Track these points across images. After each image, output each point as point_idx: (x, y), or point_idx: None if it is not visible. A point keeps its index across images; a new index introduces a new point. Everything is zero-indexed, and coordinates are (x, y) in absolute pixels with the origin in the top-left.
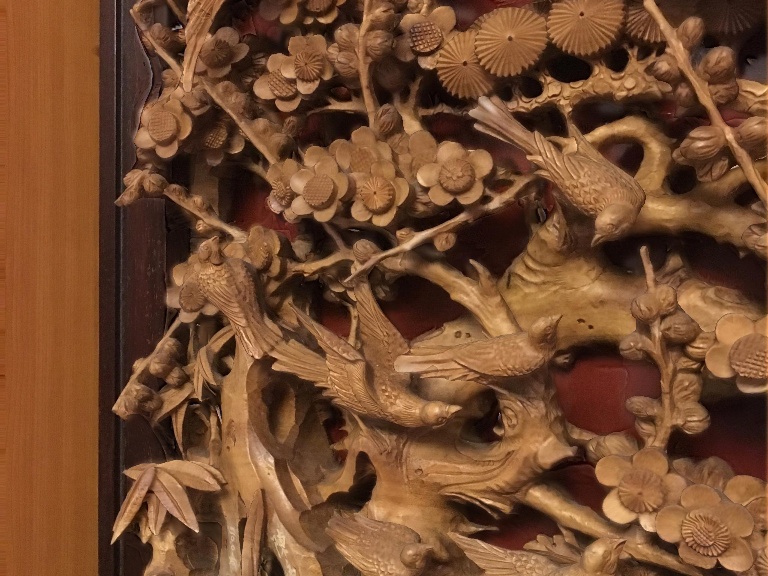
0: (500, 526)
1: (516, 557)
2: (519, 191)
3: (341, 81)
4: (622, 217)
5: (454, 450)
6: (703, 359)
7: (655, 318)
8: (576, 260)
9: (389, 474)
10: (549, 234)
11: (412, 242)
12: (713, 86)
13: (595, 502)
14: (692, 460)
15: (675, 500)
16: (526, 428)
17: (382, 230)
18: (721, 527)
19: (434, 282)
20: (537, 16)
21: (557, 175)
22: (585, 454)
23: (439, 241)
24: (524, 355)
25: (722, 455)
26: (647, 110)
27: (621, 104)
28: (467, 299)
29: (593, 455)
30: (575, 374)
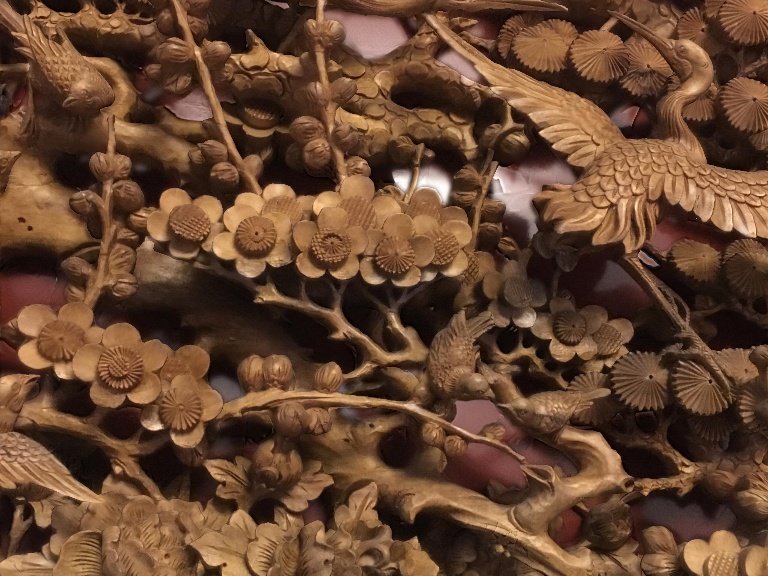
0: None
1: None
2: None
3: None
4: (96, 90)
5: None
6: (143, 229)
7: (110, 176)
8: (31, 159)
9: None
10: (12, 120)
11: None
12: (190, 16)
13: None
14: None
15: None
16: None
17: None
18: (137, 357)
19: None
20: None
21: (39, 51)
22: (2, 331)
23: None
24: None
25: None
26: (122, 59)
27: (101, 46)
28: None
29: (11, 331)
30: (1, 276)
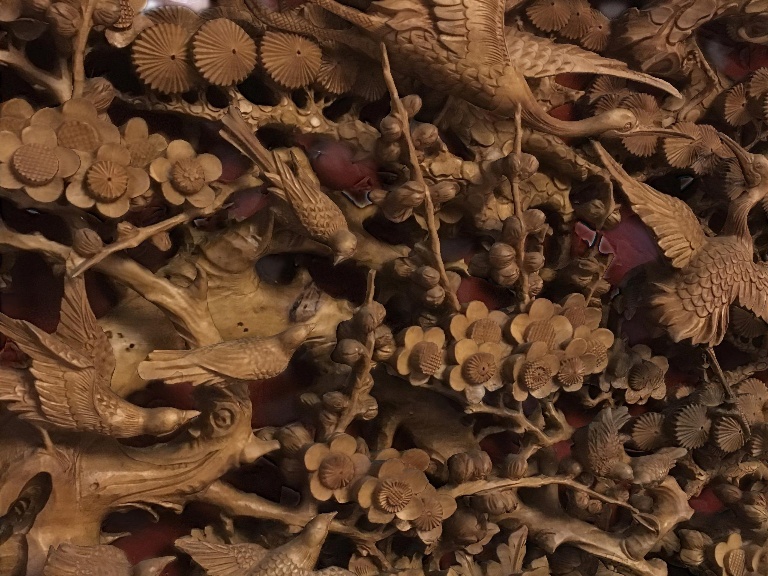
0: (133, 530)
1: (237, 550)
2: (226, 200)
3: (12, 26)
4: (356, 243)
5: (127, 458)
6: (385, 360)
7: None
8: (250, 269)
9: (66, 493)
10: (247, 244)
11: (138, 238)
12: (417, 151)
13: (258, 488)
14: None
15: (361, 474)
16: (239, 427)
17: (67, 216)
18: (409, 489)
19: (124, 280)
20: (248, 36)
21: (296, 196)
22: None
23: (162, 240)
24: (277, 360)
25: (359, 435)
26: (306, 145)
27: (290, 135)
28: (171, 301)
29: None
30: None
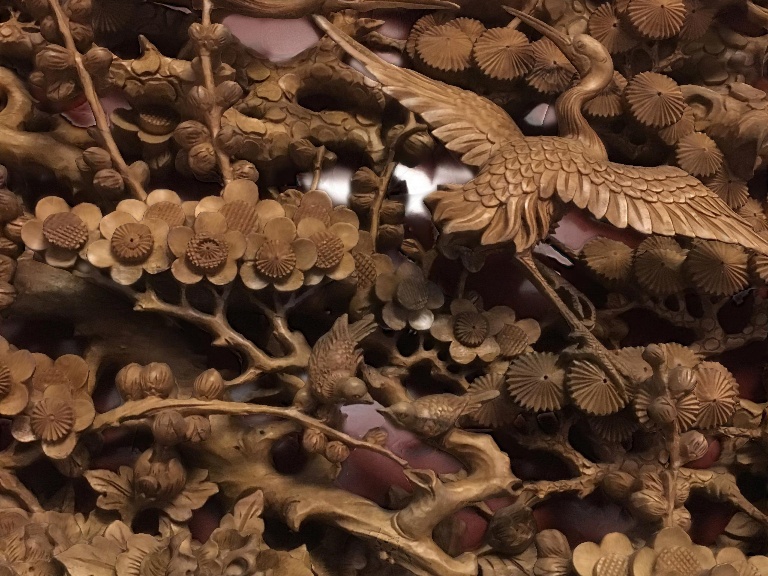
0: None
1: None
2: None
3: None
4: None
5: None
6: (20, 238)
7: None
8: None
9: None
10: None
11: None
12: (73, 23)
13: None
14: None
15: None
16: None
17: None
18: (4, 368)
19: None
20: None
21: None
22: None
23: None
24: None
25: None
26: (18, 68)
27: None
28: None
29: None
30: None
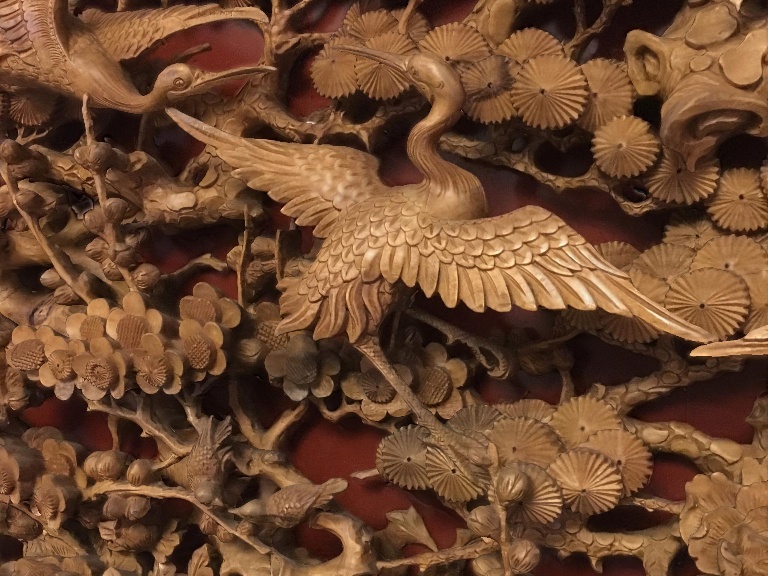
0: None
1: None
2: None
3: None
4: None
5: None
6: None
7: None
8: None
9: None
10: None
11: None
12: (11, 166)
13: None
14: (35, 429)
15: None
16: None
17: None
18: (2, 473)
19: None
20: None
21: None
22: None
23: None
24: None
25: (57, 425)
26: None
27: None
28: None
29: None
30: None
